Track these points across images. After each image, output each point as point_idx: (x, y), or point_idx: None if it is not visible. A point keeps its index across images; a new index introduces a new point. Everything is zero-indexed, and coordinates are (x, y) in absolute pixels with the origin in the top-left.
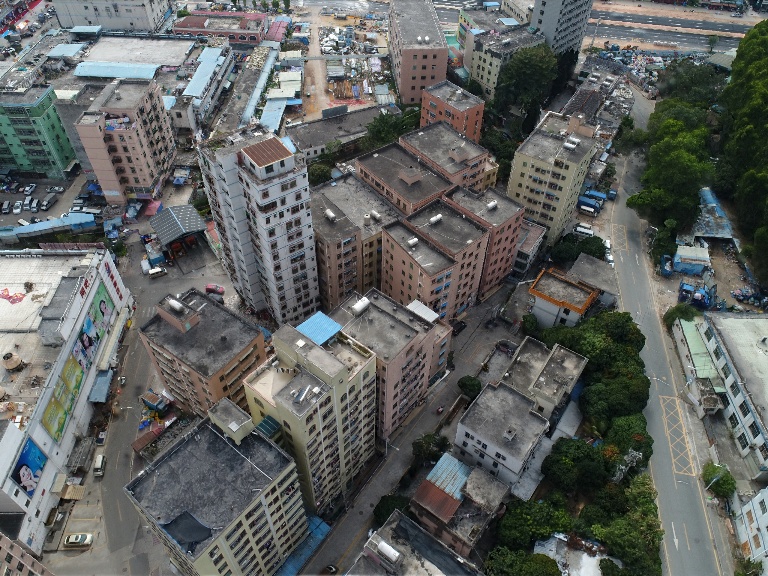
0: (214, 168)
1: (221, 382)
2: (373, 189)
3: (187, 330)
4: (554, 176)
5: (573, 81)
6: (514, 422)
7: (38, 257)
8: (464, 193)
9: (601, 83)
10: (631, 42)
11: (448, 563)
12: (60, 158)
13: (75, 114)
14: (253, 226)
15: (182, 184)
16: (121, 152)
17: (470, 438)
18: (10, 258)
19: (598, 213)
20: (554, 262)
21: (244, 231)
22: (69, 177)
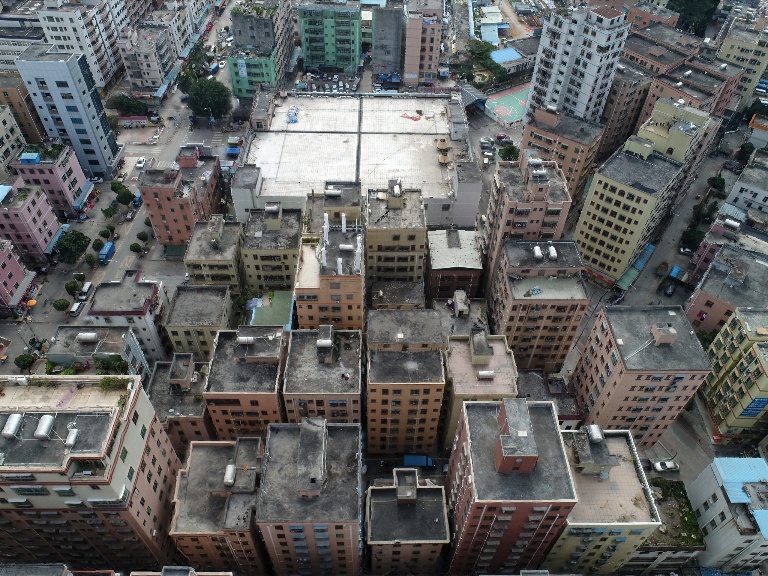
0: (568, 25)
1: (587, 153)
2: (629, 61)
3: (556, 126)
4: (756, 53)
5: (715, 15)
6: None
7: (413, 98)
8: (699, 61)
9: (744, 13)
10: None
11: (762, 236)
12: (359, 55)
13: (386, 18)
14: (580, 69)
15: (447, 76)
16: (427, 43)
17: (744, 191)
18: (395, 98)
19: (767, 94)
20: (747, 120)
21: (567, 75)
22: (359, 72)
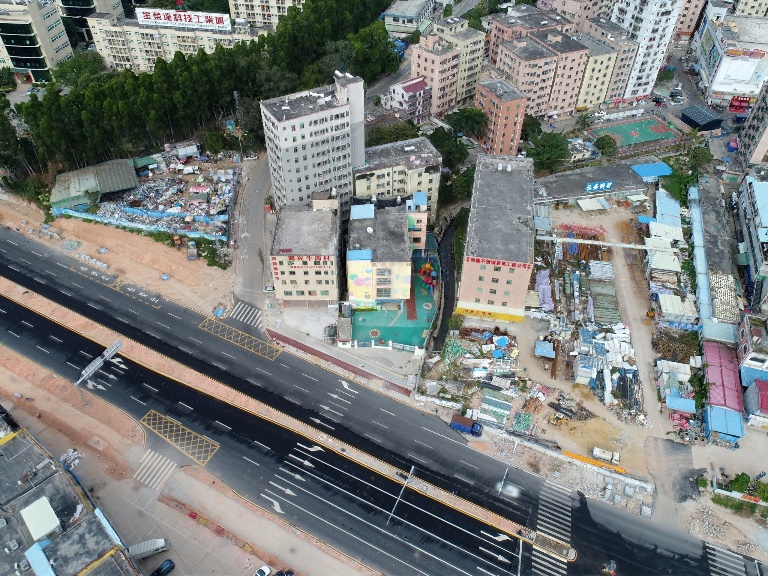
0: None
1: None
2: None
3: None
4: None
5: None
6: (521, 10)
7: None
8: None
9: None
10: (132, 279)
11: None
12: None
13: None
14: None
15: None
16: None
17: None
18: None
19: None
20: None
21: None
22: None
